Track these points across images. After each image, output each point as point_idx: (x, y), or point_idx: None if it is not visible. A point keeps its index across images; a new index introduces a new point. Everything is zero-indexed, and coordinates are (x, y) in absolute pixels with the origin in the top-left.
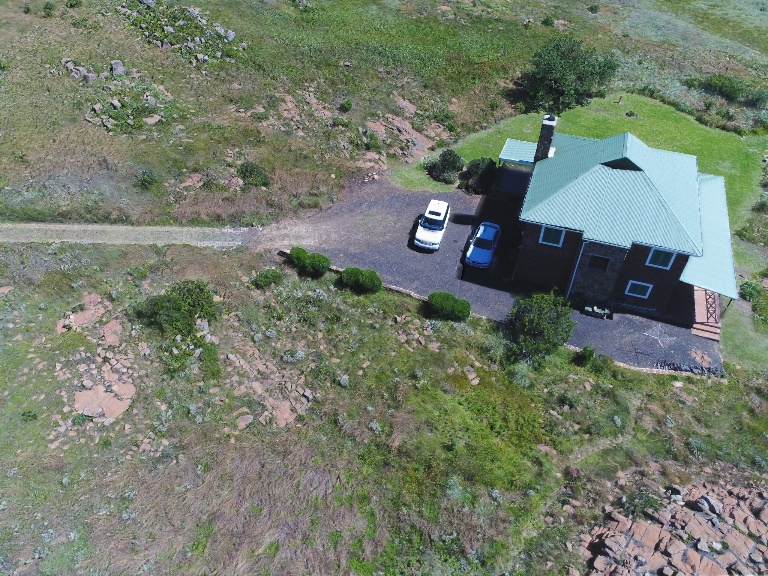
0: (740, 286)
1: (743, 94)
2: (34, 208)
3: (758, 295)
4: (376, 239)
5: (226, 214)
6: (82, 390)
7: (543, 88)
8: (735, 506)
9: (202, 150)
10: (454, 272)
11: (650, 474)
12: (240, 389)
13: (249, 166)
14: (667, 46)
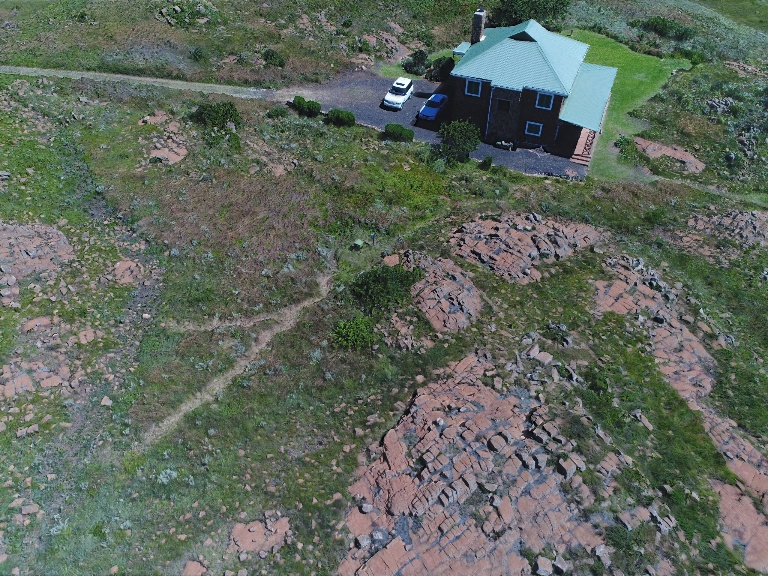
0: (617, 140)
1: (673, 31)
2: (121, 64)
3: (627, 144)
4: (357, 102)
5: (252, 79)
6: (155, 149)
7: (506, 19)
8: None
9: (237, 41)
10: (409, 122)
11: None
12: (253, 156)
13: (270, 51)
14: (630, 2)
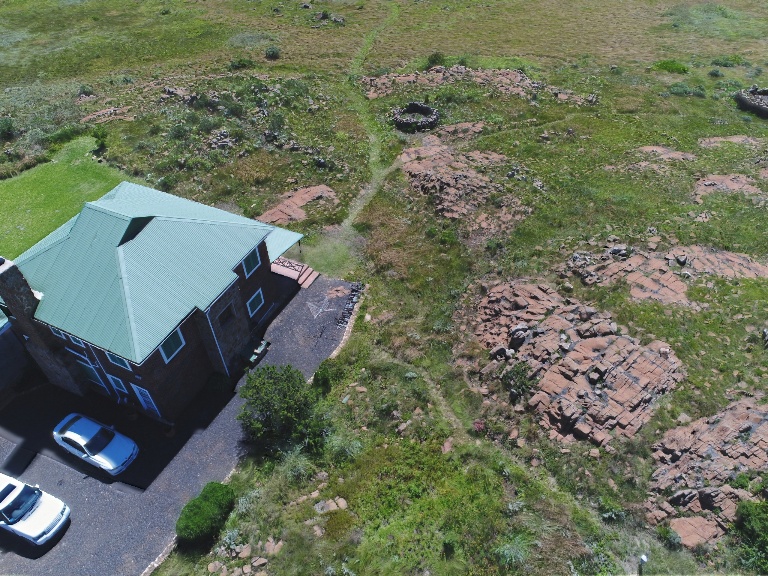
0: None
1: None
2: None
3: None
4: None
5: None
6: None
7: None
8: (513, 317)
9: None
10: (126, 496)
11: None
12: None
13: None
14: None
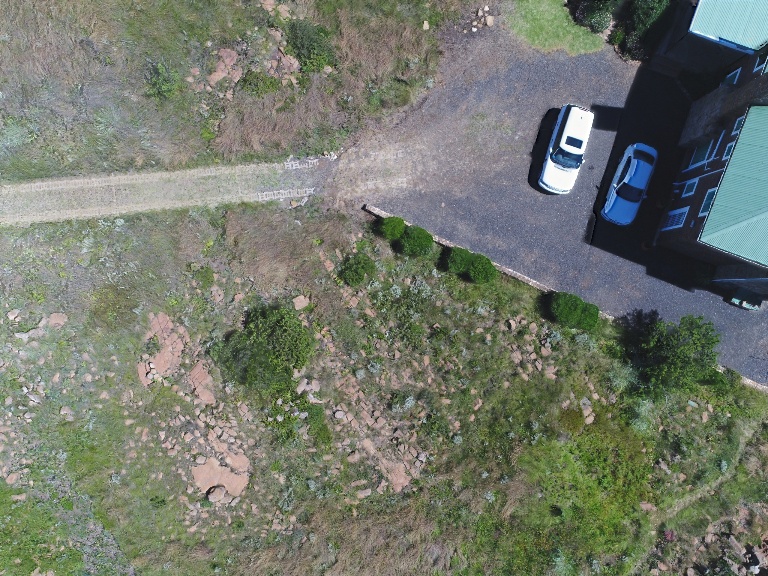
0: None
1: None
2: (30, 163)
3: None
4: (487, 169)
5: (286, 141)
6: (197, 465)
7: None
8: None
9: None
10: (583, 230)
11: (737, 527)
12: (354, 458)
13: (305, 37)
14: None
